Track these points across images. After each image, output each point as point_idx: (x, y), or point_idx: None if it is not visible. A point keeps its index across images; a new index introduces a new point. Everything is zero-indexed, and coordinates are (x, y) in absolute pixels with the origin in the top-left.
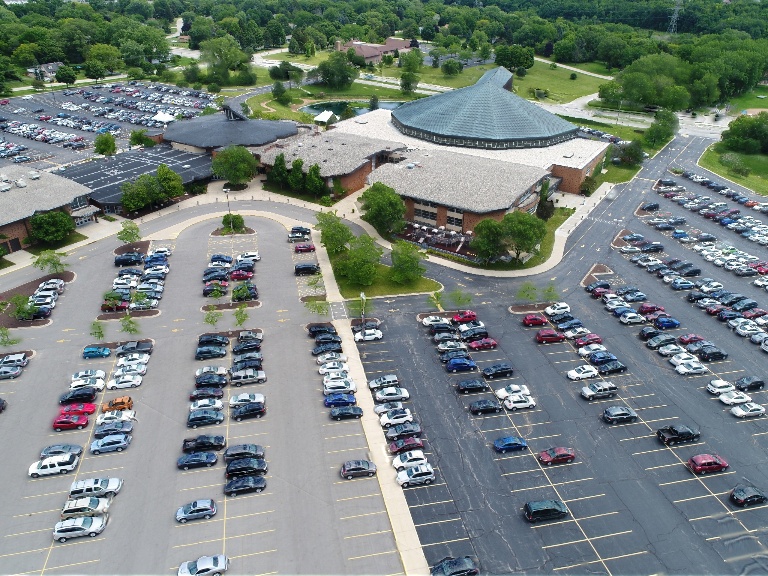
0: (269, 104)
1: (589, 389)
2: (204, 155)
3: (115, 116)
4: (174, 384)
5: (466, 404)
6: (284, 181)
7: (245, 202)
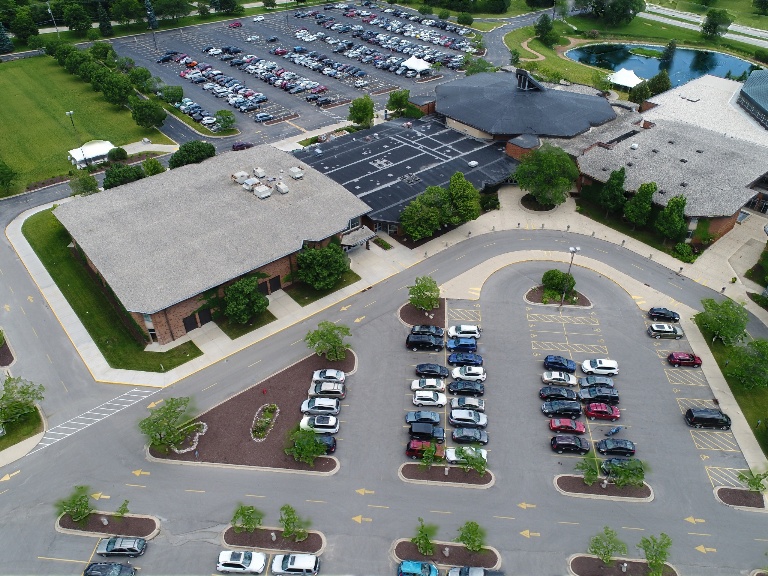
0: (531, 45)
1: None
2: (491, 143)
3: (356, 54)
4: None
5: None
6: (616, 208)
7: (558, 234)
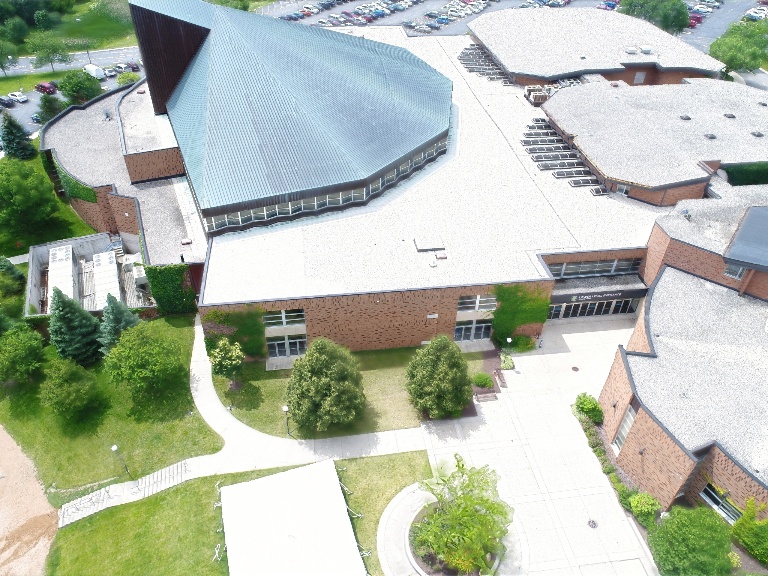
0: None
1: (716, 3)
2: None
3: None
4: None
5: None
6: None
7: None
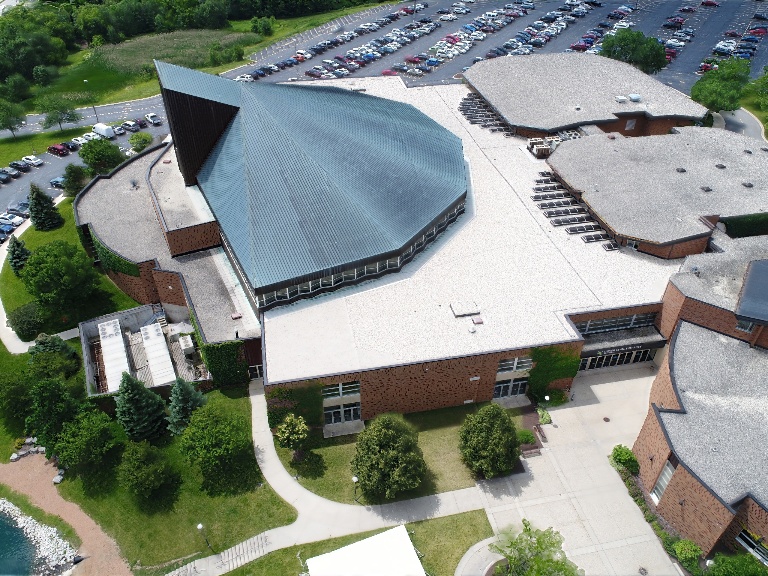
0: None
1: None
2: None
3: None
4: None
5: None
6: None
7: None
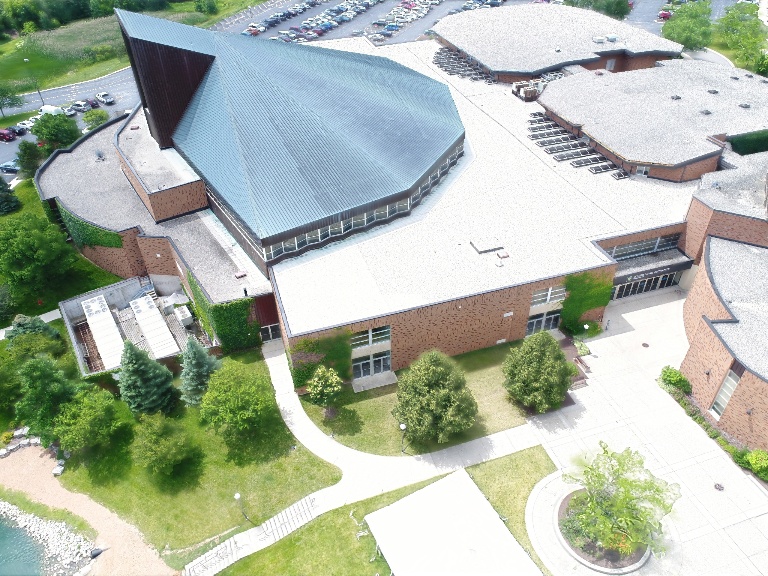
0: None
1: None
2: None
3: None
4: None
5: None
6: None
7: None
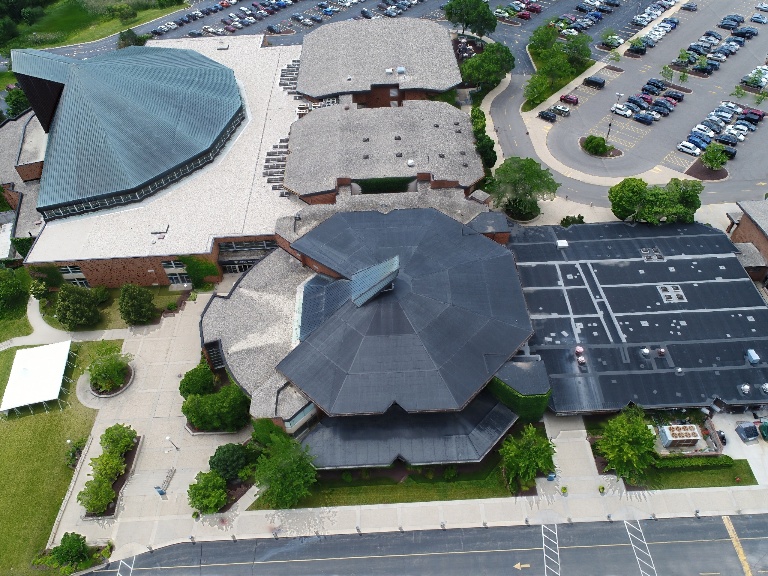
0: None
1: None
2: None
3: None
4: (739, 63)
5: (616, 8)
6: None
7: None
